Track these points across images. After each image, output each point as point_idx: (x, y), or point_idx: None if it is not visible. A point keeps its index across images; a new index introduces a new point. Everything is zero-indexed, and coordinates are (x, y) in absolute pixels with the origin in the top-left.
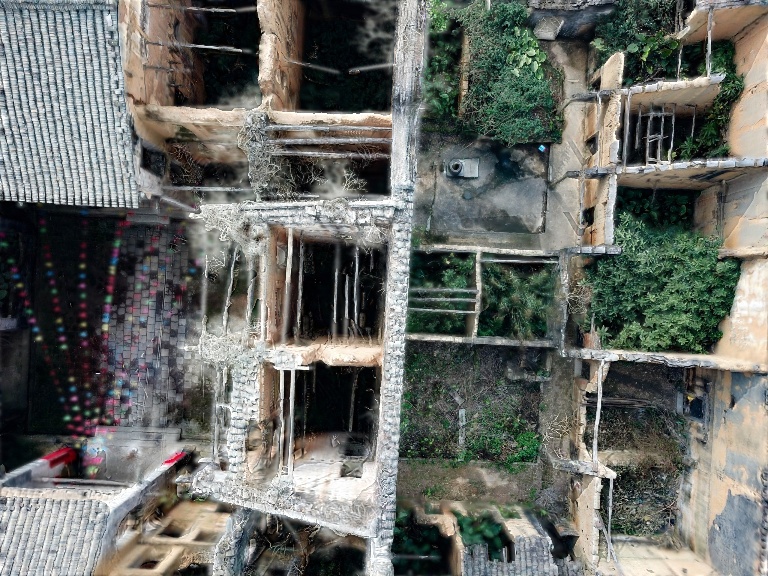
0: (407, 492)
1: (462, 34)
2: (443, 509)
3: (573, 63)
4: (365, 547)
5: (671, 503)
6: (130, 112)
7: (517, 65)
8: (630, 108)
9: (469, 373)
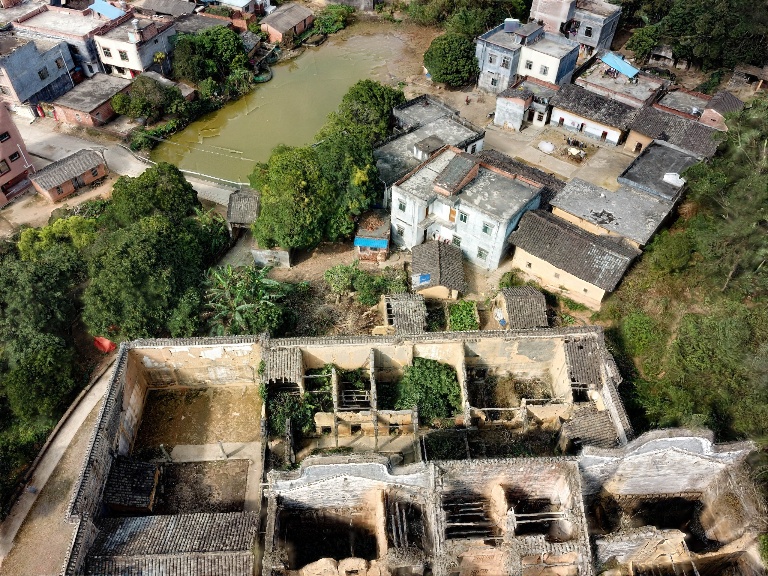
0: None
1: None
2: None
3: (308, 445)
4: (598, 508)
5: (530, 381)
6: None
7: None
8: None
9: None
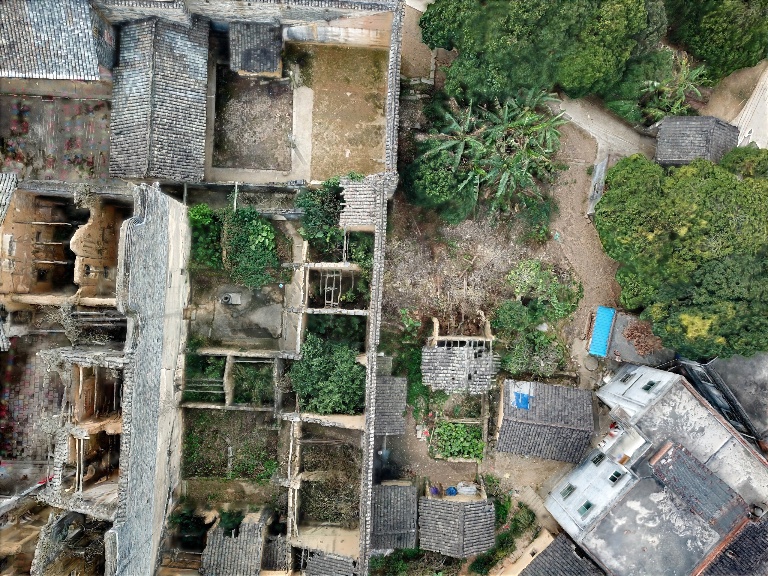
0: (196, 498)
1: (219, 226)
2: (213, 508)
3: (298, 234)
4: None
5: (355, 502)
6: (2, 303)
7: (254, 243)
8: (318, 270)
9: (235, 425)
